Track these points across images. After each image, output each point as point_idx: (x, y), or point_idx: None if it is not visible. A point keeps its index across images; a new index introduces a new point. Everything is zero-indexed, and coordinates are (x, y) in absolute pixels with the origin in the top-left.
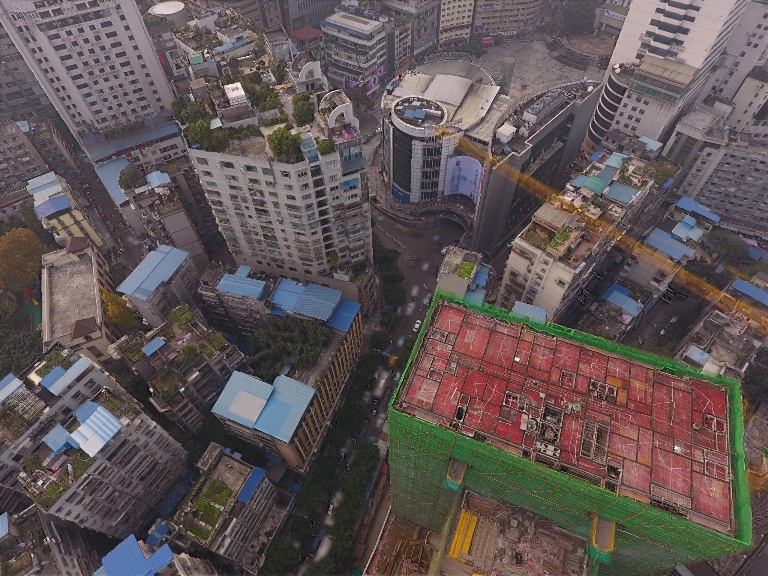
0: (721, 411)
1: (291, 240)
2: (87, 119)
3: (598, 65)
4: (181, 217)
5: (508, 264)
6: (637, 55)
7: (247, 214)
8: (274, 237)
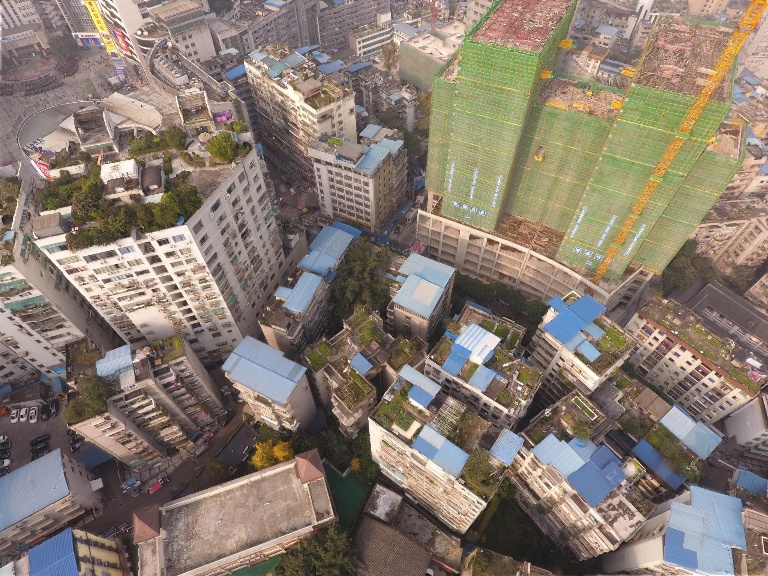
0: None
1: (267, 241)
2: None
3: (64, 75)
4: (186, 346)
5: None
6: (142, 16)
7: (237, 253)
8: (256, 255)
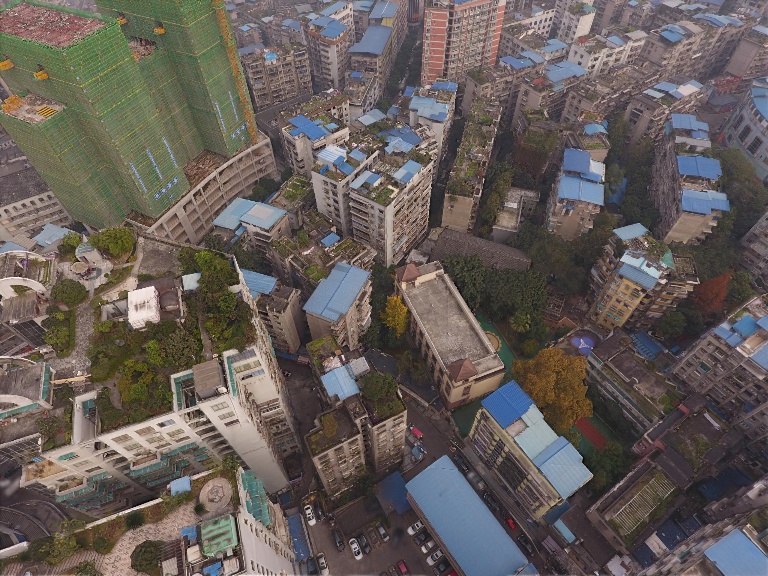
0: None
1: None
2: None
3: None
4: None
5: None
6: None
7: None
8: None
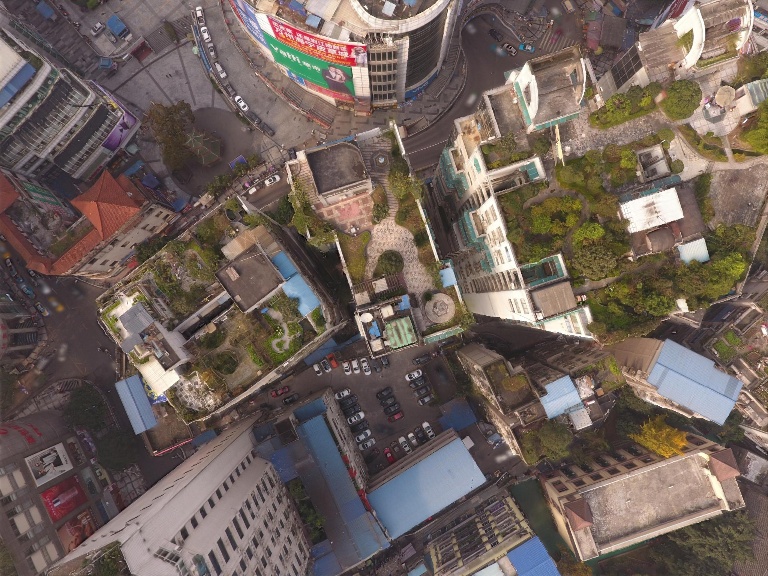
0: None
1: None
2: None
3: None
4: None
5: None
6: None
7: None
8: None
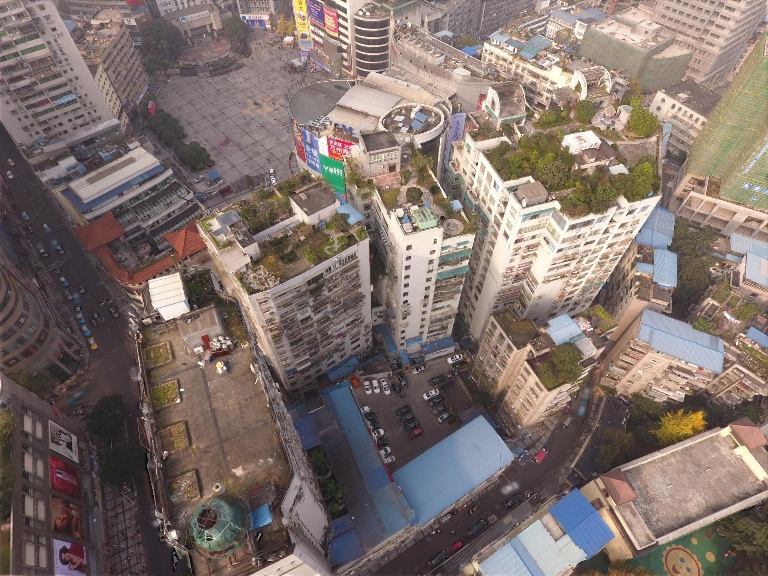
0: None
1: None
2: (319, 538)
3: (241, 56)
4: None
5: None
6: None
7: None
8: None
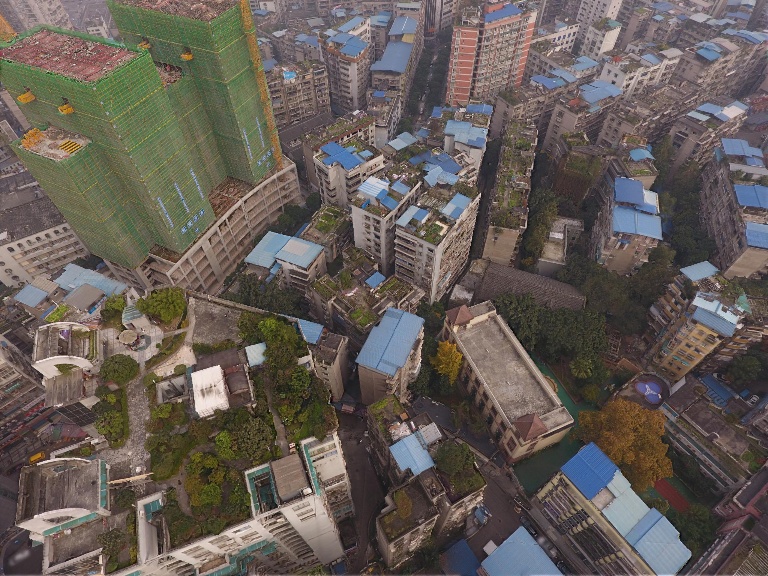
0: (4, 50)
1: None
2: None
3: None
4: None
5: (6, 361)
6: None
7: None
8: None
